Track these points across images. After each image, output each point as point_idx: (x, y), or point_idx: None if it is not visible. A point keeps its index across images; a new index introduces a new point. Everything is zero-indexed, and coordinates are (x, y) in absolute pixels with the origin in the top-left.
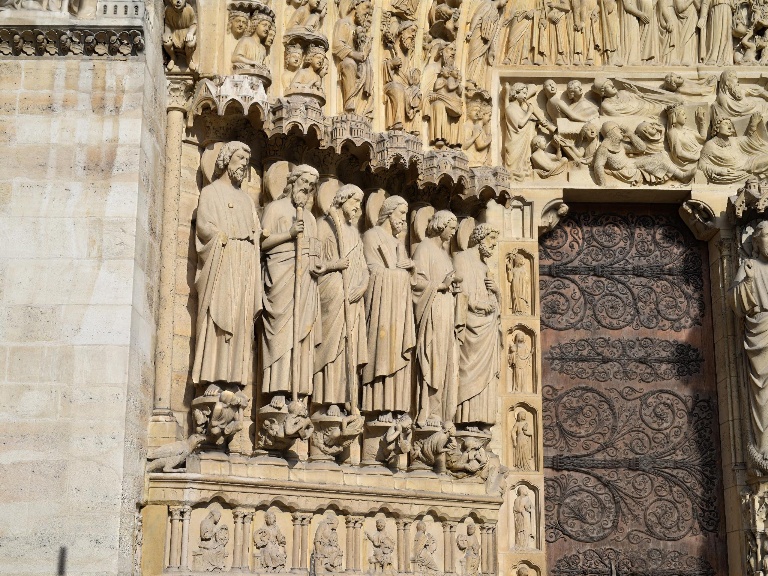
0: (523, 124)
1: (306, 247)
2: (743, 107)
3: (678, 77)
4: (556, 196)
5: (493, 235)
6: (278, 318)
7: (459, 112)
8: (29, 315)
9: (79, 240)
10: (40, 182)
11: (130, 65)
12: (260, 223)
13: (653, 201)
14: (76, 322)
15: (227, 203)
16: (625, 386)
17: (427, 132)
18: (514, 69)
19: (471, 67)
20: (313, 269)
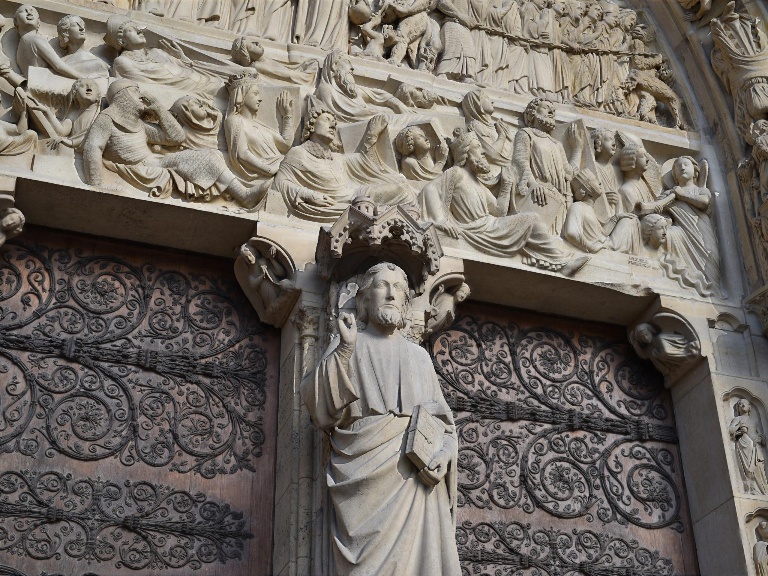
0: None
1: None
2: (357, 107)
3: (254, 42)
4: (0, 186)
5: None
6: None
7: None
8: None
9: None
10: None
11: None
12: None
13: (190, 246)
14: None
15: None
16: (85, 572)
17: None
18: None
19: None
20: None
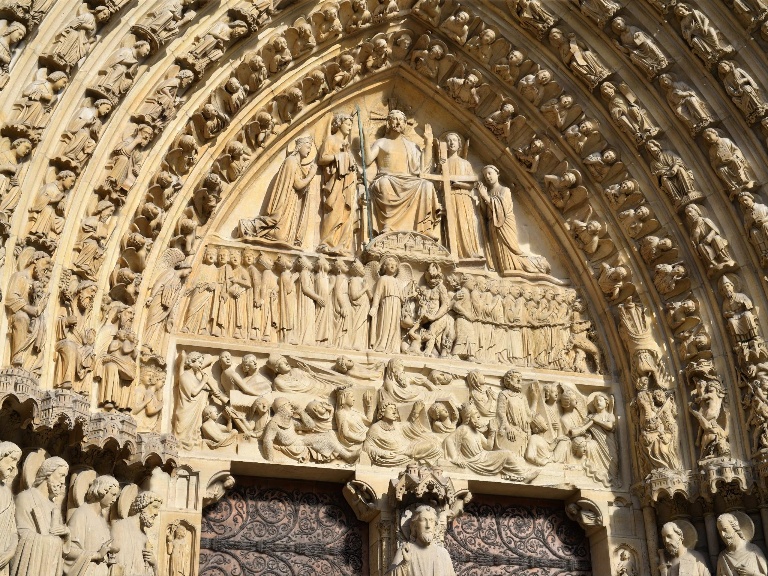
0: (196, 393)
1: None
2: (407, 394)
3: (349, 360)
4: (223, 468)
5: (156, 504)
6: None
7: (132, 376)
8: None
9: None
10: None
11: None
12: None
13: (319, 479)
14: None
15: None
16: None
17: (97, 393)
18: (192, 338)
19: (148, 332)
20: None
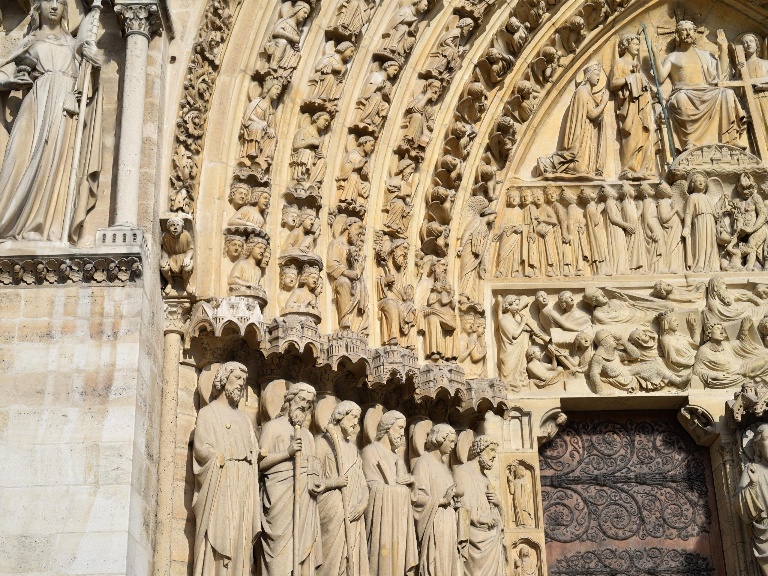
0: (517, 335)
1: (304, 466)
2: (733, 312)
3: (667, 285)
4: (554, 406)
5: (492, 447)
6: (277, 540)
7: (453, 326)
8: (23, 545)
9: (75, 466)
10: (37, 409)
11: (128, 291)
12: (258, 443)
13: (651, 407)
14: (71, 551)
15: (224, 424)
16: None
17: (422, 346)
18: (506, 282)
19: (463, 281)
20: (312, 488)
